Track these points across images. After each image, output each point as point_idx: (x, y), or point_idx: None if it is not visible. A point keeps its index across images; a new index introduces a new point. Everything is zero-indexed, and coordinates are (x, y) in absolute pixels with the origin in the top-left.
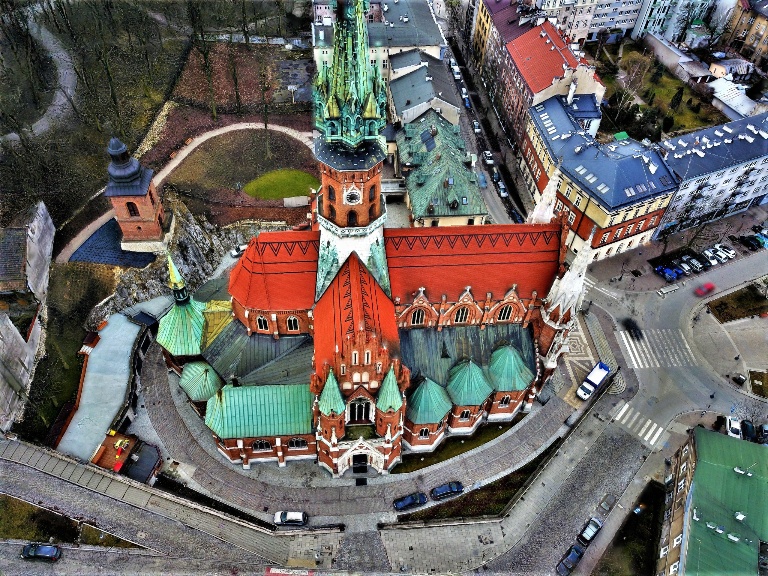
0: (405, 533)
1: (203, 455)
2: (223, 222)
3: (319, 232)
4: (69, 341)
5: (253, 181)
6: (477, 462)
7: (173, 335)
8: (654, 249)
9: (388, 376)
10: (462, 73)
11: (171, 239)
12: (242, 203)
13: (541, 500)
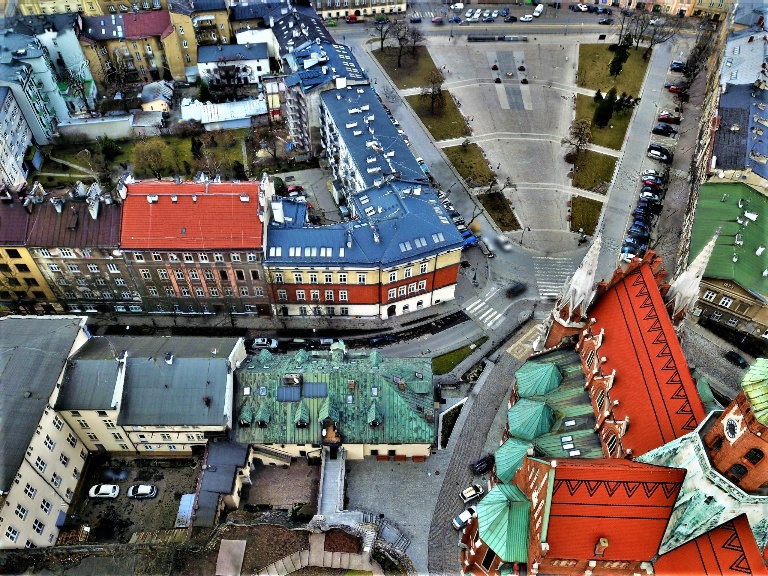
0: None
1: None
2: None
3: None
4: None
5: None
6: None
7: None
8: None
9: None
10: None
11: None
12: None
13: None
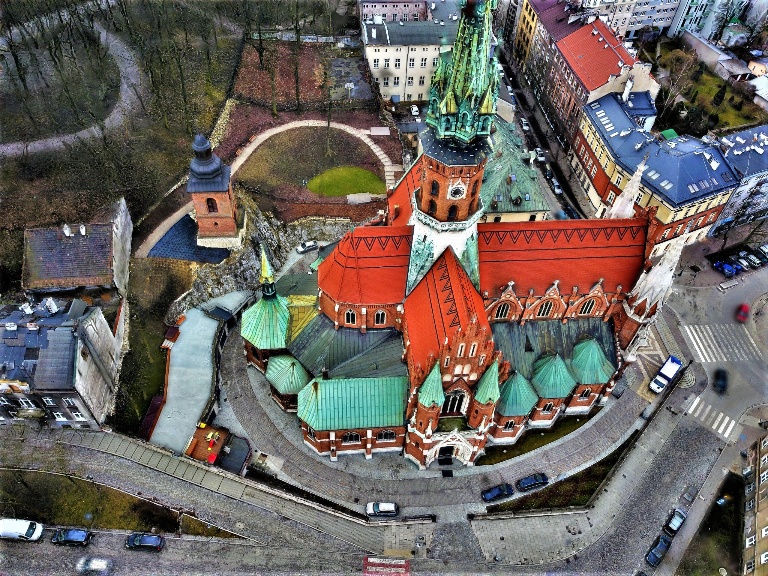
0: (495, 524)
1: (290, 447)
2: (289, 218)
3: (413, 227)
4: (151, 335)
5: (315, 178)
6: (558, 454)
7: (259, 329)
8: (710, 245)
9: (492, 368)
10: (505, 71)
11: (244, 235)
12: (306, 200)
13: (624, 491)
